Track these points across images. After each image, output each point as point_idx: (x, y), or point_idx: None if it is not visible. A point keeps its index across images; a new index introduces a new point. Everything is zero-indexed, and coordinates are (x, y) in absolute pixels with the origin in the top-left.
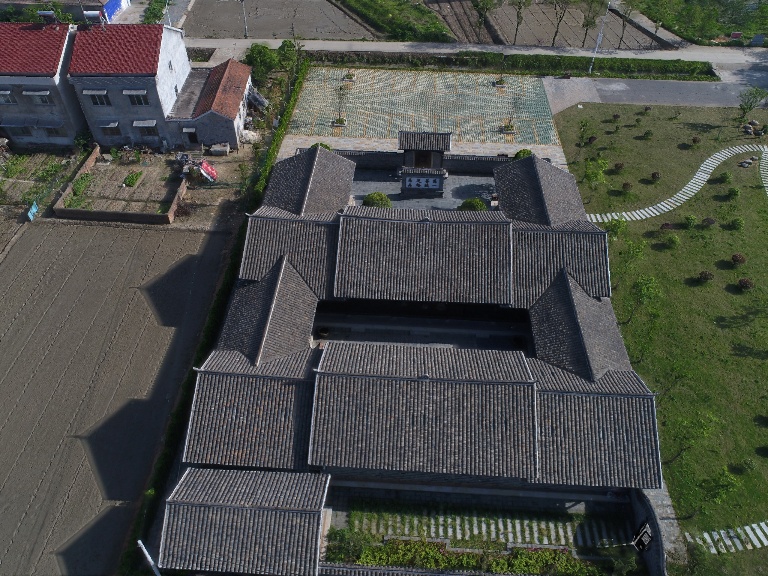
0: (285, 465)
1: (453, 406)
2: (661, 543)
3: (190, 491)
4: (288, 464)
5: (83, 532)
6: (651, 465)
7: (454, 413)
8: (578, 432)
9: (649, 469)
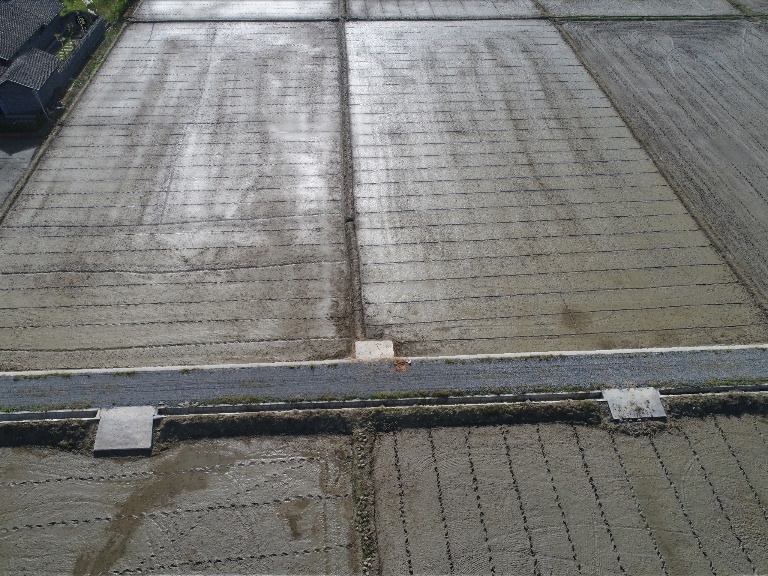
0: (4, 69)
1: (1, 21)
2: (85, 11)
3: (4, 79)
4: (4, 68)
5: (3, 149)
6: (54, 2)
7: (5, 22)
8: (31, 8)
9: (56, 3)
